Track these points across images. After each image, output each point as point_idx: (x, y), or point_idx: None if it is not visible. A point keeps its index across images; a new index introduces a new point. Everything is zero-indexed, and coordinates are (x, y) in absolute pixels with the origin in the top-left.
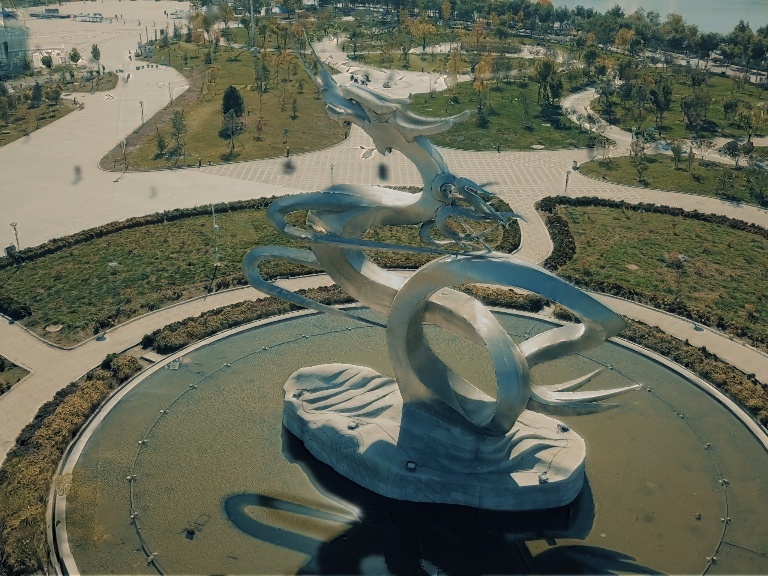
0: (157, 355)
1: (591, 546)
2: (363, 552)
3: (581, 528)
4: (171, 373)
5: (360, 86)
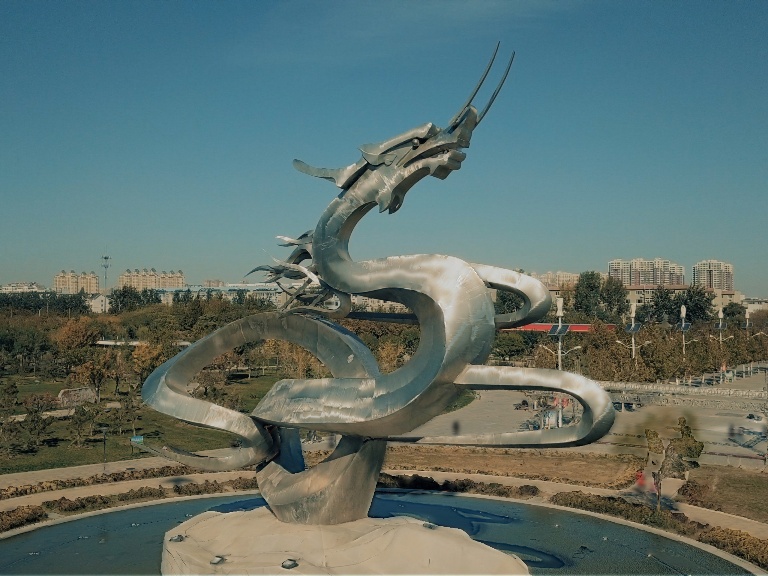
0: None
1: None
2: None
3: None
4: None
5: (420, 127)
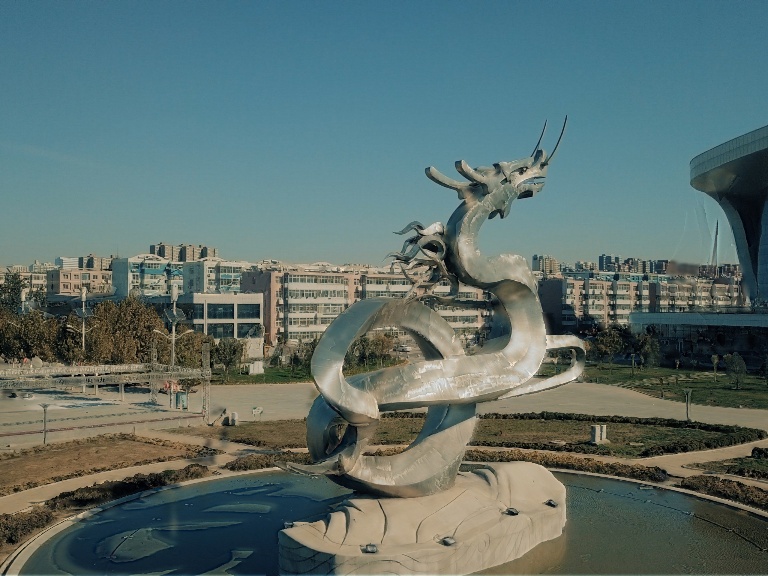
0: (669, 483)
1: (213, 570)
2: (311, 515)
3: (240, 572)
4: (631, 487)
5: None
